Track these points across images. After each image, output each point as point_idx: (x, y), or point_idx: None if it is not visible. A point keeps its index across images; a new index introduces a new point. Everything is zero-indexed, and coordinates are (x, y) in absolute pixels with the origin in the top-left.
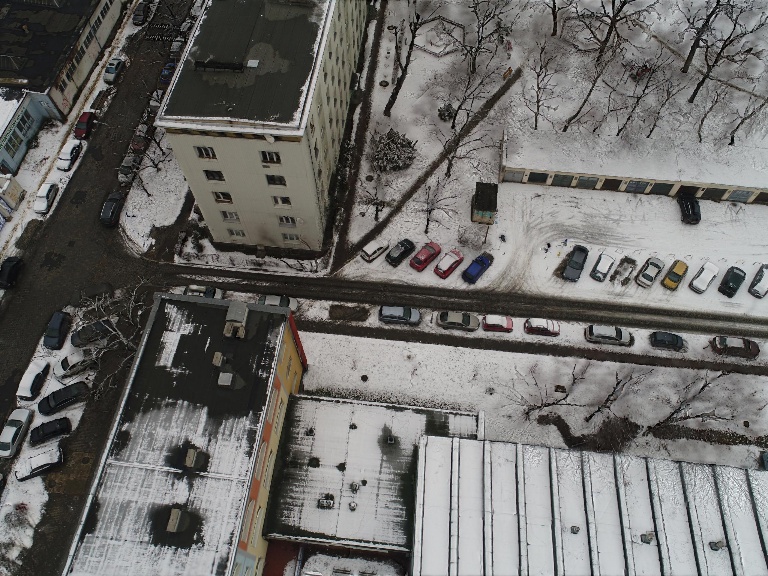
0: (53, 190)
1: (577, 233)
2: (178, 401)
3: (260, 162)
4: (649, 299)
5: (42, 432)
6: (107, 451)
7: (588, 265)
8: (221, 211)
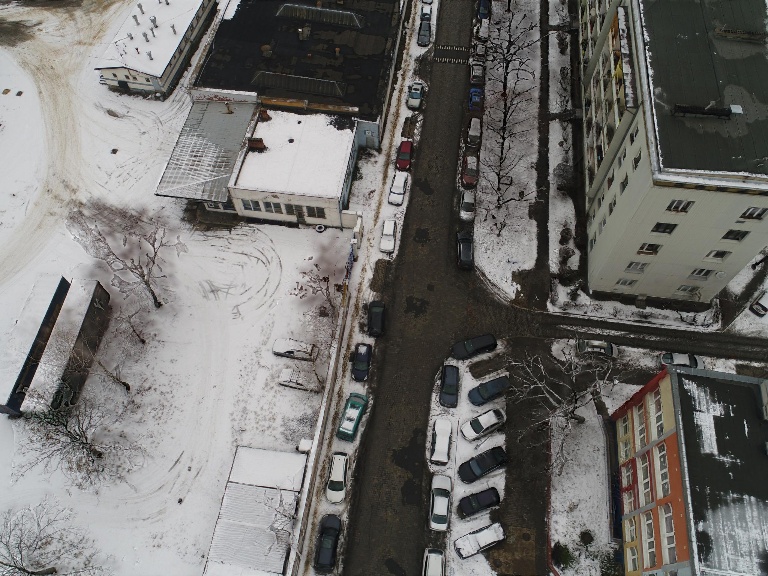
0: (395, 227)
1: None
2: (744, 496)
3: (737, 217)
4: None
5: (476, 504)
6: (697, 556)
7: None
8: (632, 262)
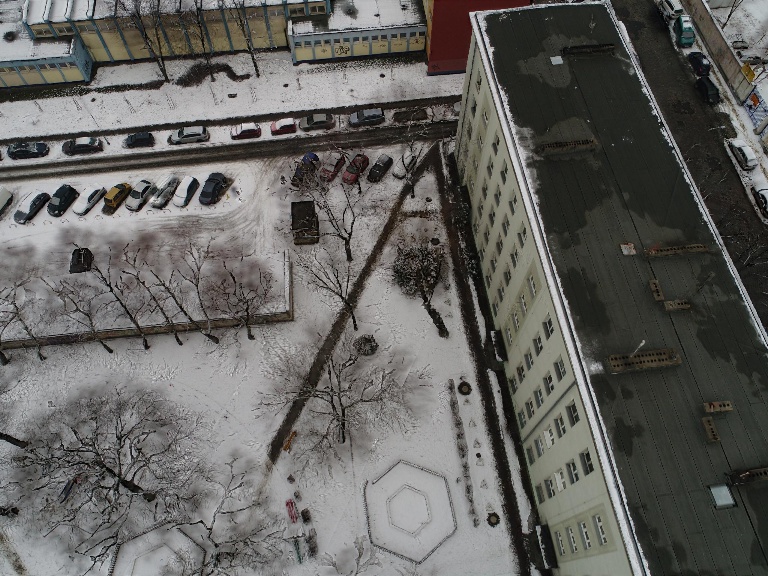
0: (743, 159)
1: (208, 223)
2: None
3: None
4: (147, 175)
5: None
6: None
7: None
8: None
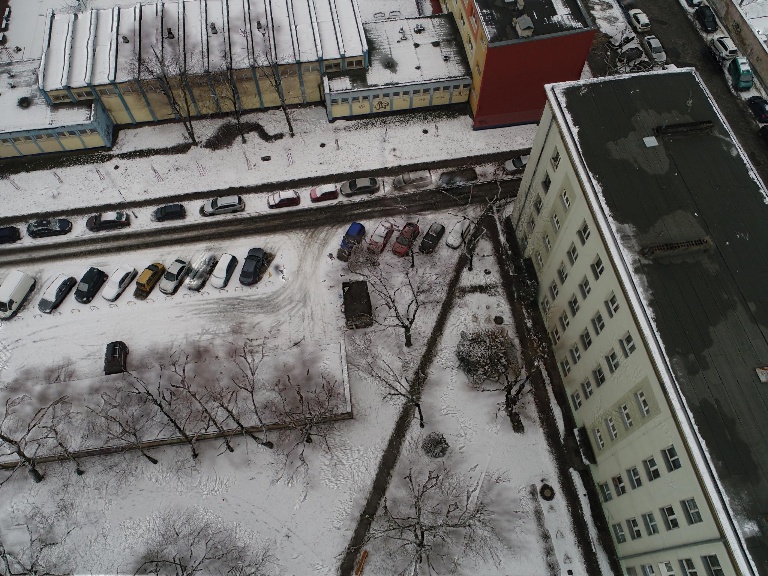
0: None
1: (250, 306)
2: None
3: None
4: (180, 252)
5: None
6: None
7: (239, 272)
8: None
